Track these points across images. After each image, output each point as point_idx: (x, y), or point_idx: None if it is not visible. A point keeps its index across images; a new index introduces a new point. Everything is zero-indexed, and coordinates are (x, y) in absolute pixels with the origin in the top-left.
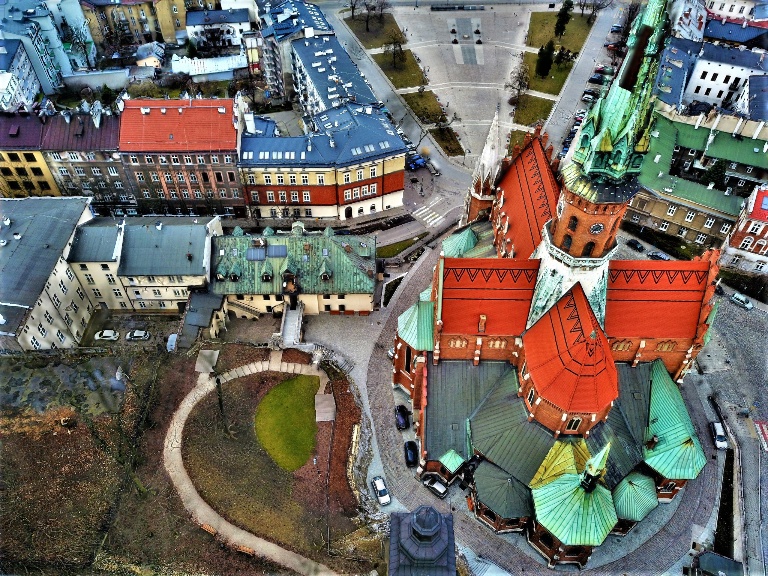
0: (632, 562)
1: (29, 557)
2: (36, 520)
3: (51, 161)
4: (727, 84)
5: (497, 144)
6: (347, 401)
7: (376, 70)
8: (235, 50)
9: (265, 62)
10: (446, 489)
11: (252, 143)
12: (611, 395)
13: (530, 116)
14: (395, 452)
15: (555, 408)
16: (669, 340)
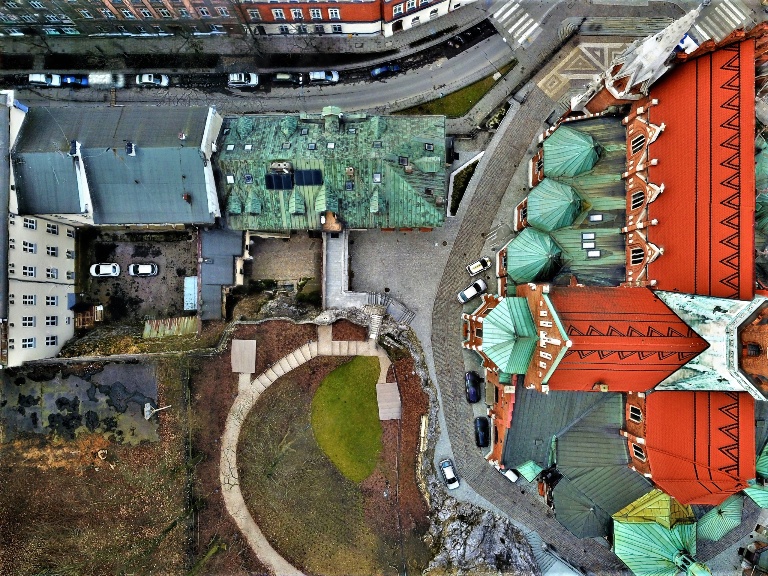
0: None
1: None
2: (114, 575)
3: None
4: None
5: None
6: (413, 386)
7: None
8: None
9: None
10: (518, 477)
11: None
12: None
13: None
14: (464, 428)
15: None
16: None
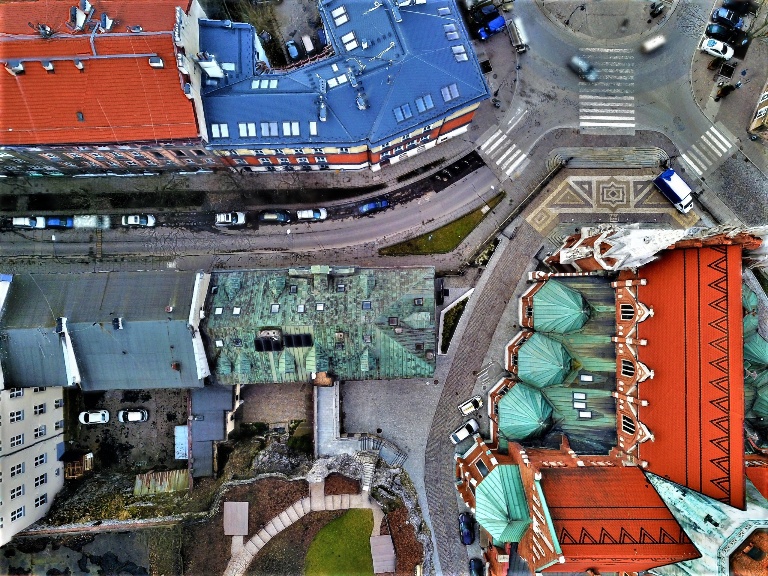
0: None
1: None
2: None
3: None
4: None
5: None
6: (406, 536)
7: None
8: None
9: None
10: None
11: (222, 107)
12: None
13: None
14: (459, 569)
15: None
16: None
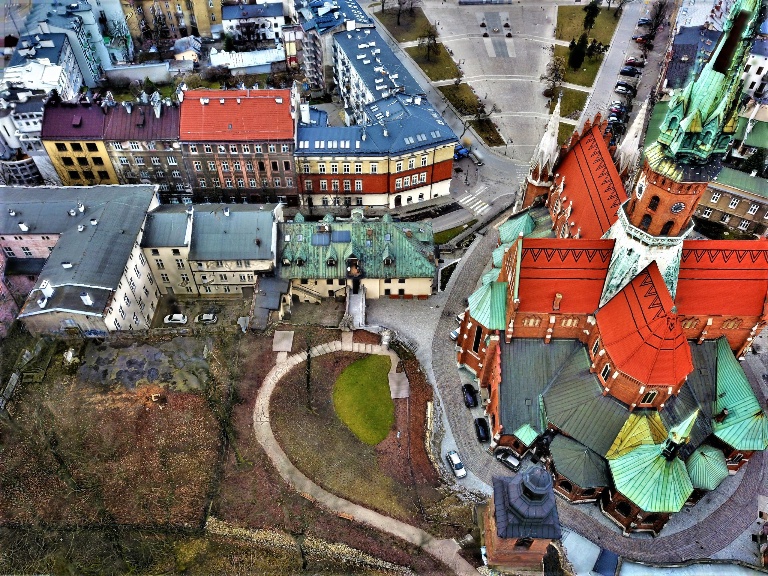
0: (703, 530)
1: (141, 522)
2: (141, 489)
3: (112, 151)
4: (760, 75)
5: (557, 131)
6: (418, 379)
7: (410, 63)
8: (269, 44)
9: (305, 55)
10: (519, 462)
11: (308, 133)
12: (687, 369)
13: (566, 107)
14: (466, 428)
15: (633, 381)
16: (736, 318)
